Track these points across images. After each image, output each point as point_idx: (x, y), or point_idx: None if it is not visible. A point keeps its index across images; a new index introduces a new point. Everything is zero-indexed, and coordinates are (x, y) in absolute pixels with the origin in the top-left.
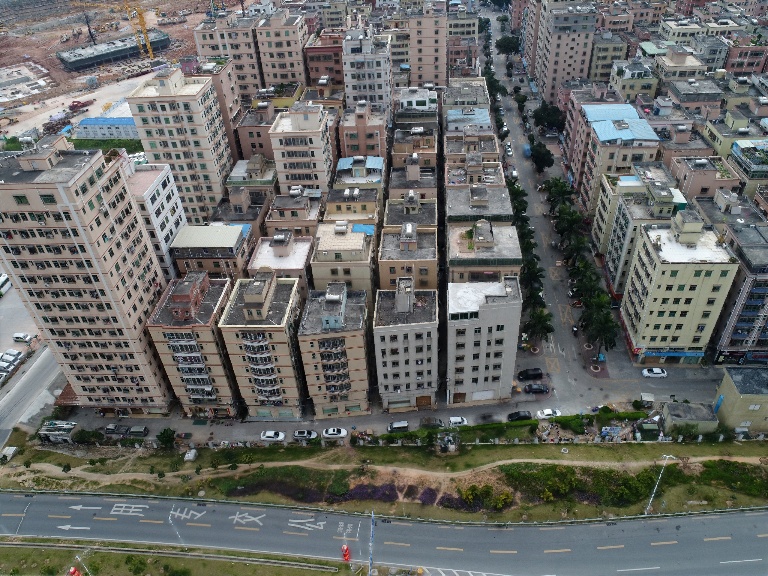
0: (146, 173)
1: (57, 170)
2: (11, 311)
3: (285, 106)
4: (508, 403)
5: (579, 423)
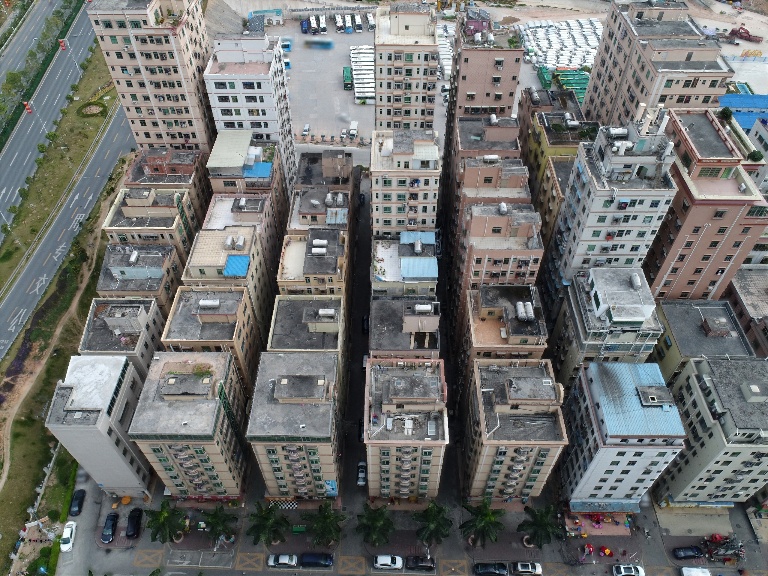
0: (263, 69)
1: (124, 3)
2: (345, 115)
3: (542, 148)
4: (104, 493)
5: (39, 569)
